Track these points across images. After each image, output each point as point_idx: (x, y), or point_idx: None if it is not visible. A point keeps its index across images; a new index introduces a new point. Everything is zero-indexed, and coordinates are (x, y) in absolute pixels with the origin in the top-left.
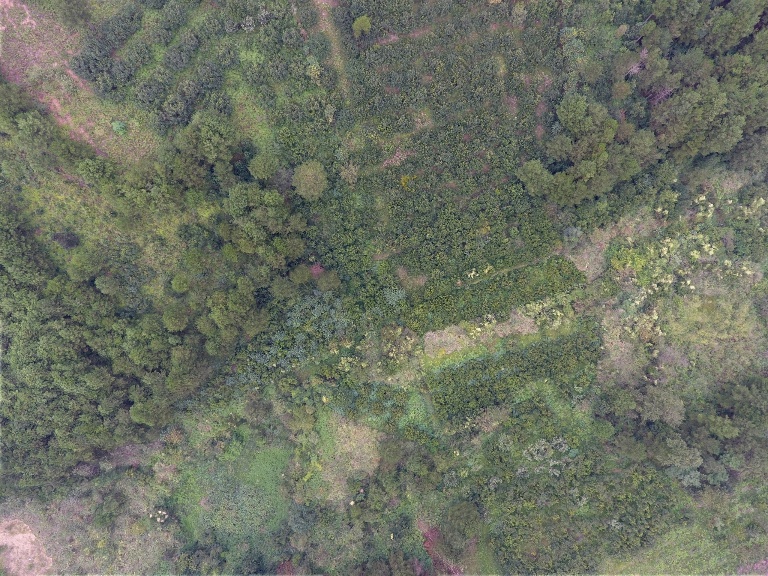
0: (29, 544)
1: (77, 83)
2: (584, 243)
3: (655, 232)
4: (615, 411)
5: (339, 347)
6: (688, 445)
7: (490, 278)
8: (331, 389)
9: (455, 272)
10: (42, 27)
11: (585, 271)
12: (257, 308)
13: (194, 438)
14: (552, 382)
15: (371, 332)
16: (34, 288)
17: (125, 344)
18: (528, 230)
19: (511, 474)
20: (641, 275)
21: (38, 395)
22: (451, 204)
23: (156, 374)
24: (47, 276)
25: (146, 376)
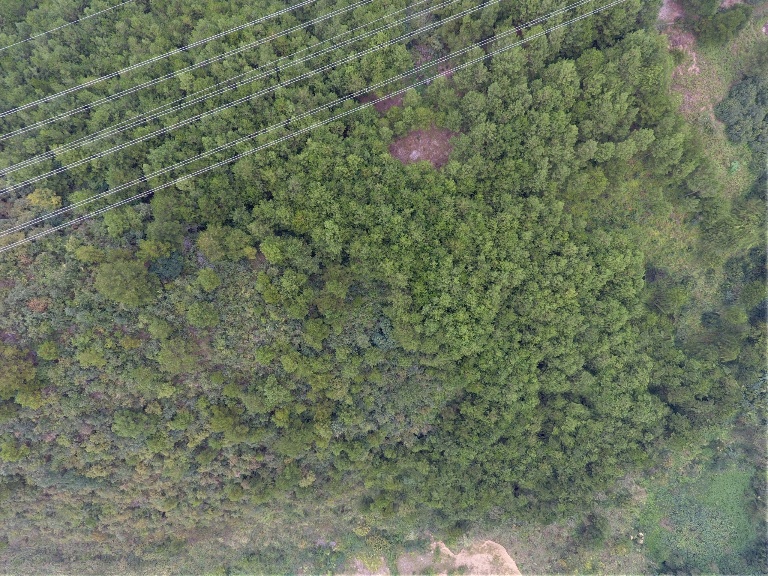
0: (488, 564)
1: (712, 126)
2: None
3: None
4: None
5: None
6: None
7: None
8: None
9: None
10: (704, 73)
11: None
12: None
13: (675, 462)
14: None
15: None
16: (637, 322)
17: (686, 374)
18: None
19: None
20: None
21: None
22: None
23: (706, 403)
24: (649, 310)
25: (698, 405)
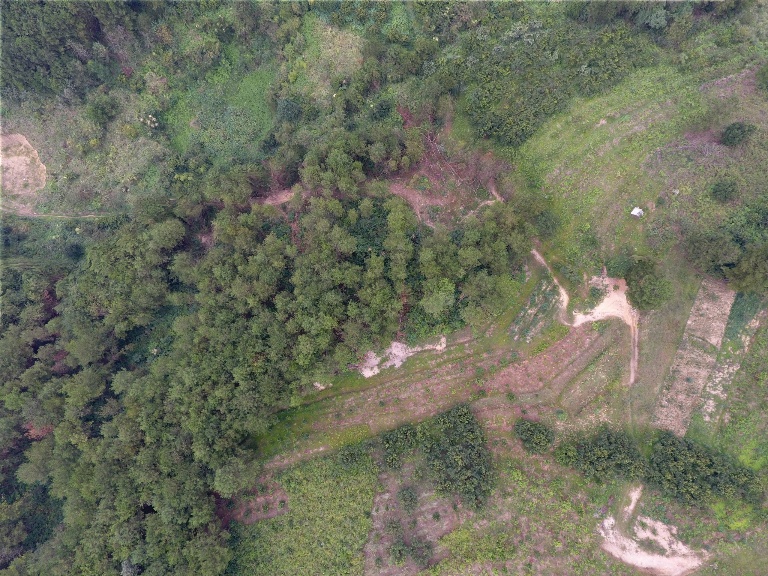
0: (24, 166)
1: None
2: None
3: None
4: None
5: None
6: None
7: None
8: None
9: None
10: None
11: None
12: None
13: (184, 45)
14: None
15: None
16: None
17: None
18: None
19: (487, 53)
20: None
21: None
22: None
23: None
24: None
25: None
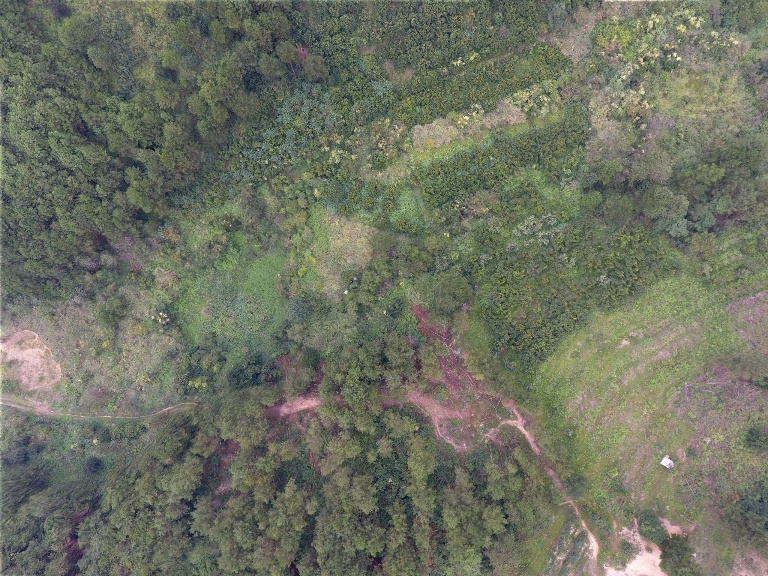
0: (39, 358)
1: None
2: (569, 25)
3: (641, 12)
4: (603, 180)
5: (329, 142)
6: (675, 194)
7: (476, 67)
8: (322, 182)
9: (441, 63)
10: None
11: (571, 55)
12: (246, 89)
13: (191, 240)
14: (541, 167)
15: (360, 128)
16: (29, 51)
17: (119, 119)
18: (513, 14)
19: (501, 250)
20: (627, 51)
21: (38, 167)
22: None
23: (150, 151)
24: (41, 40)
25: (140, 153)
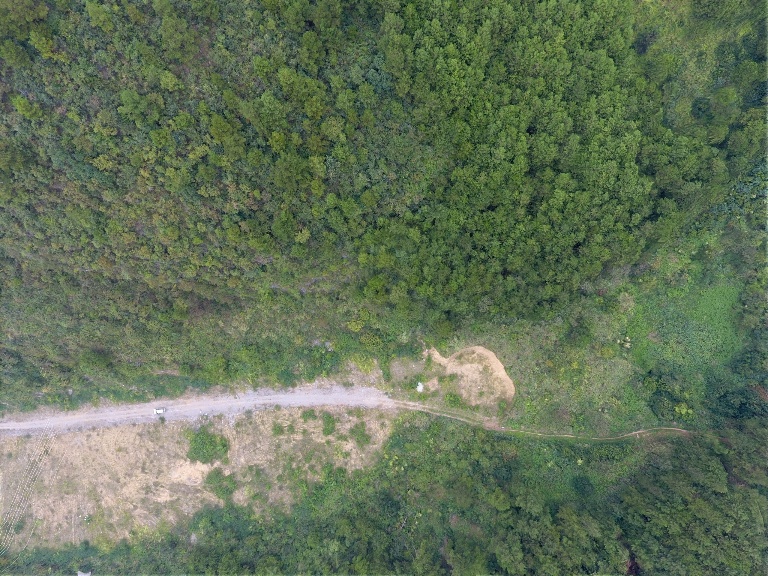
0: (477, 373)
1: None
2: None
3: None
4: None
5: None
6: None
7: None
8: None
9: None
10: None
11: None
12: None
13: (664, 268)
14: None
15: None
16: (626, 85)
17: (674, 152)
18: None
19: None
20: None
21: (598, 196)
22: None
23: (693, 184)
24: (638, 74)
25: (685, 186)
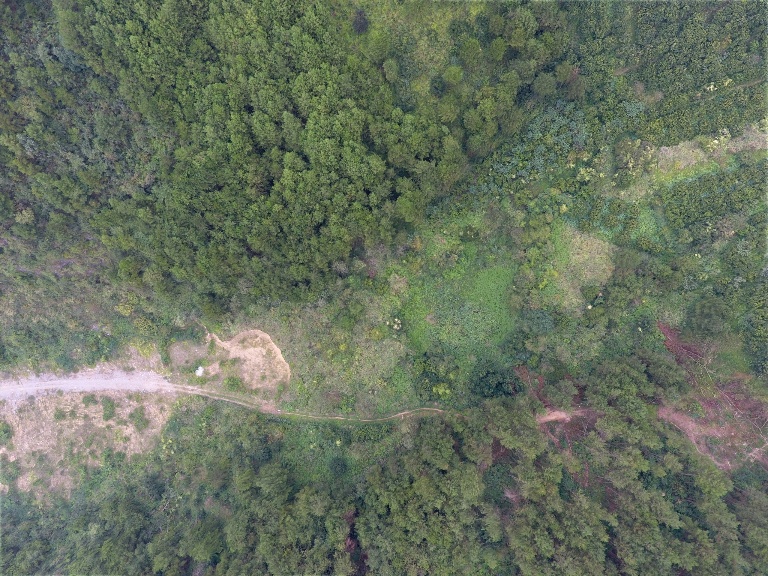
0: (260, 357)
1: None
2: None
3: None
4: None
5: (576, 160)
6: None
7: (727, 93)
8: (570, 199)
9: (692, 87)
10: None
11: None
12: (518, 106)
13: (430, 249)
14: None
15: (607, 146)
16: (336, 63)
17: (403, 130)
18: None
19: (755, 274)
20: None
21: (324, 175)
22: (699, 13)
23: (427, 163)
24: (348, 52)
25: (418, 164)
